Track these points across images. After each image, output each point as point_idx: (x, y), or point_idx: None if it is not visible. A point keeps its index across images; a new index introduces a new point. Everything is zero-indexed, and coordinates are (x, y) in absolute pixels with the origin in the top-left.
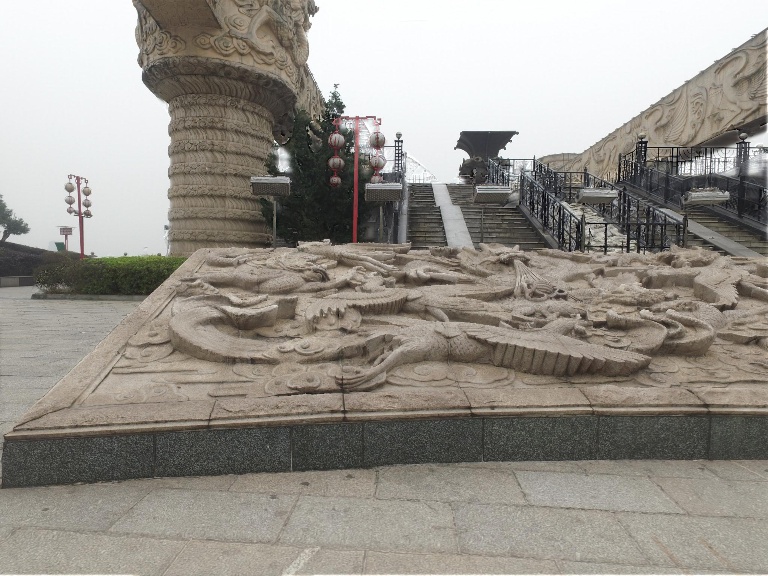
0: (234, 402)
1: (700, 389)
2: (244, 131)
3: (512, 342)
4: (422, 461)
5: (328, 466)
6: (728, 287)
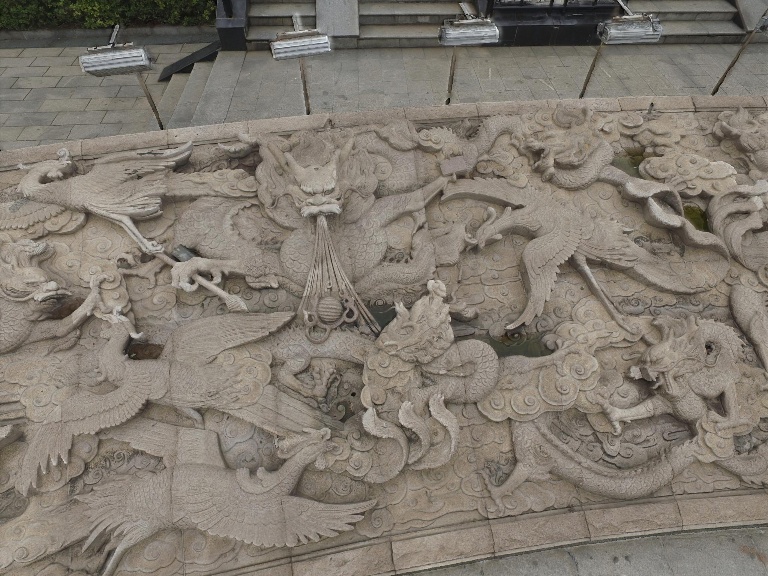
0: None
1: (398, 551)
2: None
3: (232, 533)
4: None
5: None
6: (550, 275)
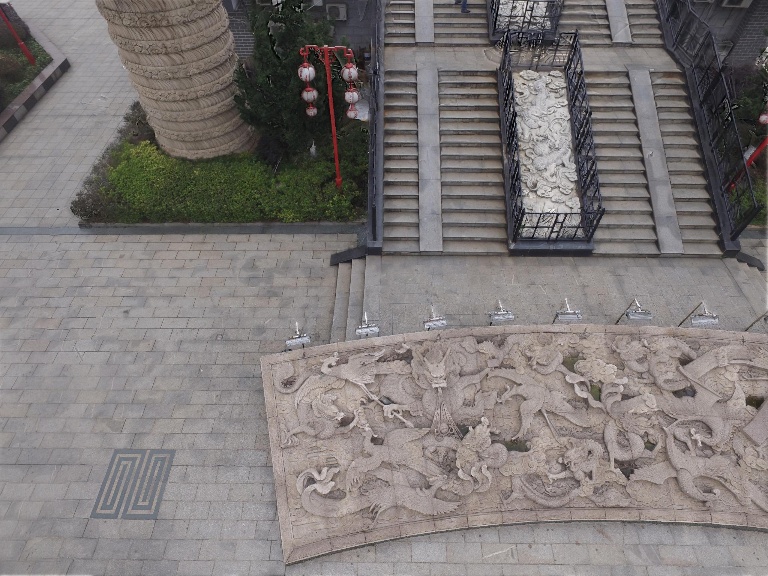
0: (336, 544)
1: (470, 520)
2: (192, 19)
3: (416, 509)
4: (387, 542)
5: (363, 547)
6: (530, 418)
